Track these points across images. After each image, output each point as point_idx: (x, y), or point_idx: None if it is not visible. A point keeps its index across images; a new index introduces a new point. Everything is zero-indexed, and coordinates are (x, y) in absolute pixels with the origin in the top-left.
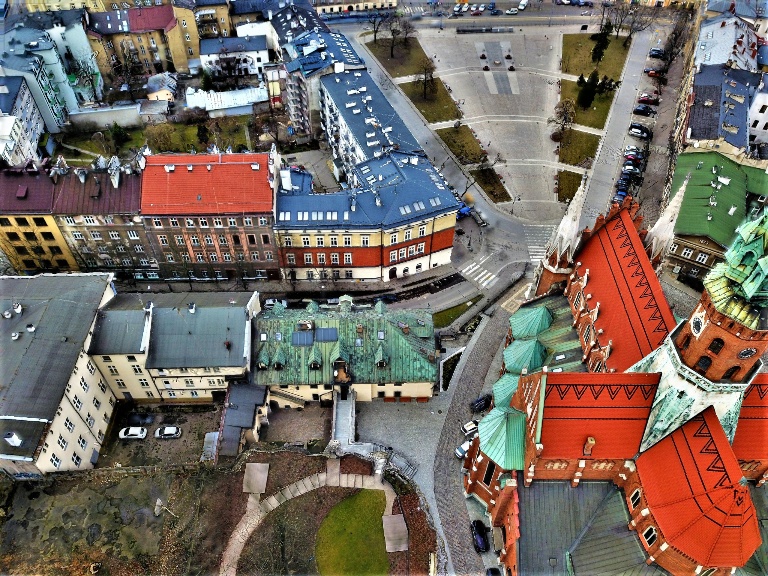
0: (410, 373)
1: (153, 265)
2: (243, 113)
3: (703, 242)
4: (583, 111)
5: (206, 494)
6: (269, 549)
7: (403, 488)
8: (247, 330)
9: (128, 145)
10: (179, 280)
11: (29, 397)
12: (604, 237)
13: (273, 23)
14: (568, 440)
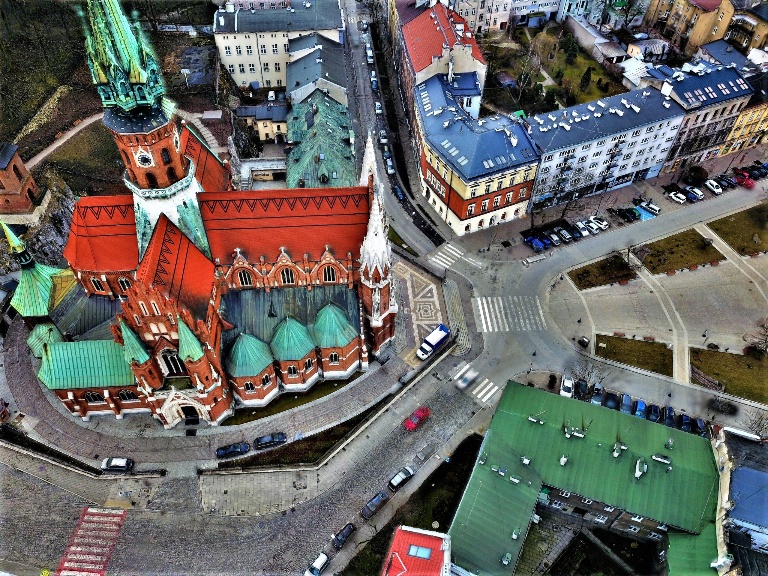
0: None
1: None
2: None
3: None
4: None
5: (200, 95)
6: None
7: None
8: (306, 86)
9: None
10: None
11: (250, 22)
12: None
13: None
14: None
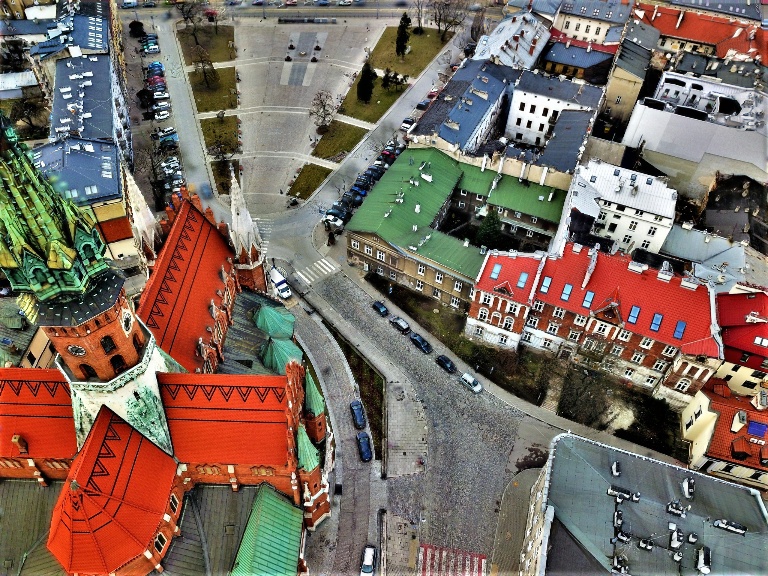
0: None
1: None
2: (13, 97)
3: (376, 239)
4: (365, 104)
5: None
6: None
7: None
8: None
9: None
10: None
11: None
12: (171, 229)
13: (57, 6)
14: (2, 437)
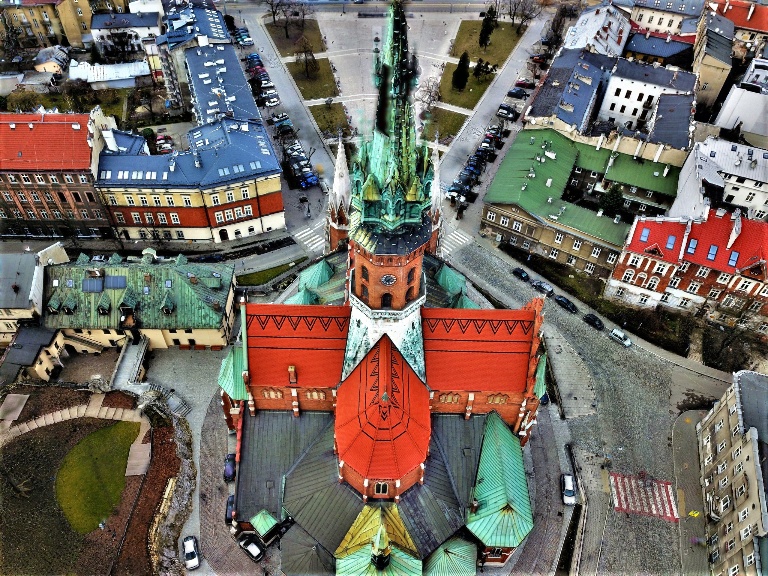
0: (195, 320)
1: None
2: (126, 86)
3: (515, 210)
4: (458, 92)
5: None
6: (6, 468)
7: (160, 421)
8: (35, 275)
9: None
10: (16, 237)
11: None
12: None
13: None
14: (275, 369)
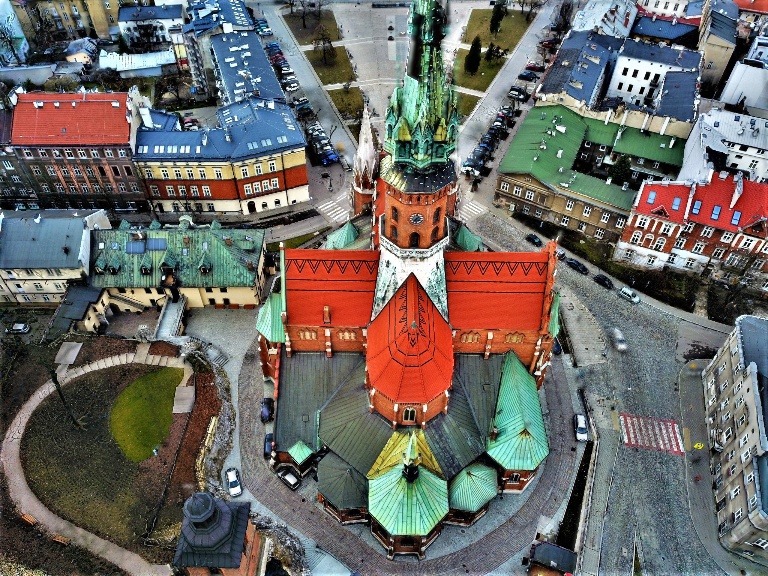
0: (230, 279)
1: (32, 195)
2: (153, 74)
3: (527, 180)
4: (471, 76)
5: (19, 362)
6: None
7: (202, 368)
8: (84, 237)
9: None
10: None
11: None
12: None
13: None
14: (310, 310)
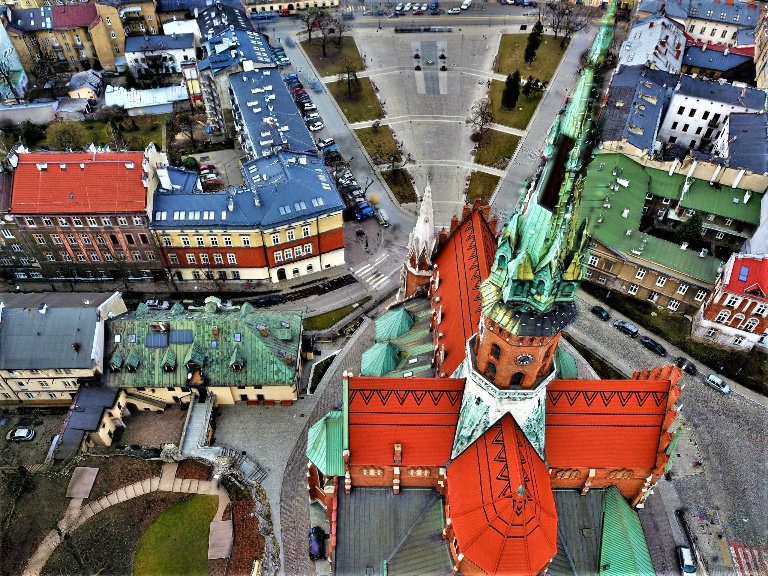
0: (266, 376)
1: (34, 264)
2: (163, 111)
3: (592, 244)
4: (508, 111)
5: (23, 499)
6: (81, 556)
7: (239, 493)
8: (97, 331)
9: (40, 143)
10: (64, 280)
11: None
12: (457, 239)
13: (198, 21)
14: (377, 446)
